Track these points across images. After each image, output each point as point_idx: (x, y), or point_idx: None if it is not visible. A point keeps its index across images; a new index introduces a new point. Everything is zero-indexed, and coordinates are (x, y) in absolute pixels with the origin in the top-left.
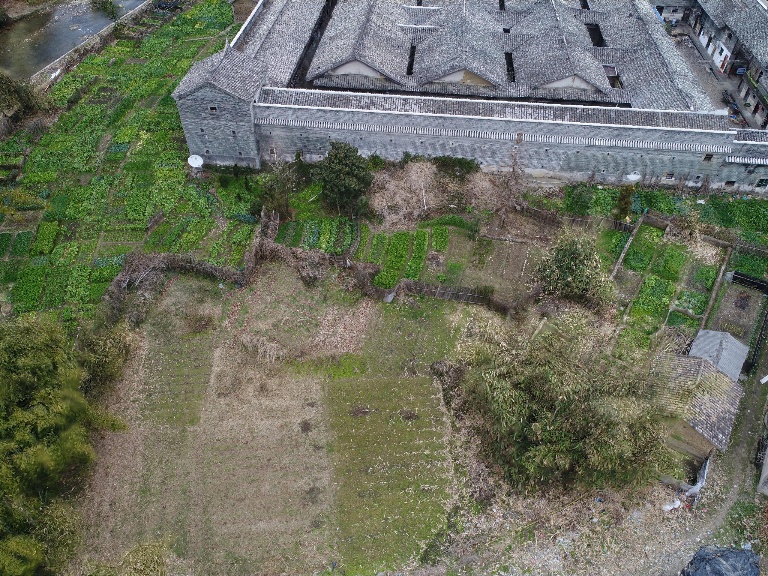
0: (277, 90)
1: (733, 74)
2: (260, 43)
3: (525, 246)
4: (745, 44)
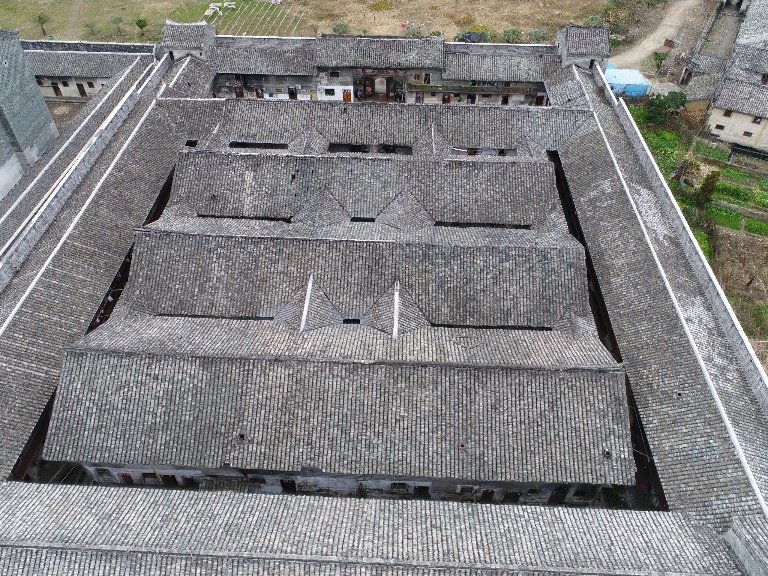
0: (766, 505)
1: (359, 100)
2: (605, 572)
3: (764, 274)
4: (388, 66)
